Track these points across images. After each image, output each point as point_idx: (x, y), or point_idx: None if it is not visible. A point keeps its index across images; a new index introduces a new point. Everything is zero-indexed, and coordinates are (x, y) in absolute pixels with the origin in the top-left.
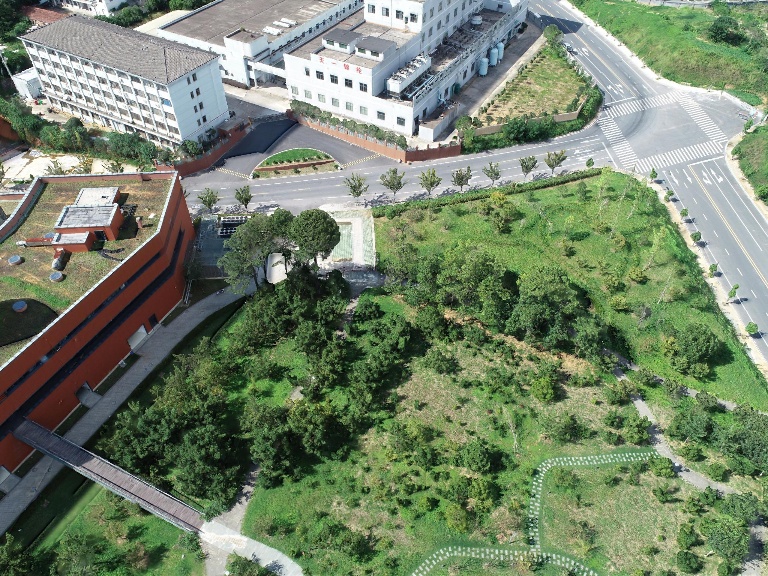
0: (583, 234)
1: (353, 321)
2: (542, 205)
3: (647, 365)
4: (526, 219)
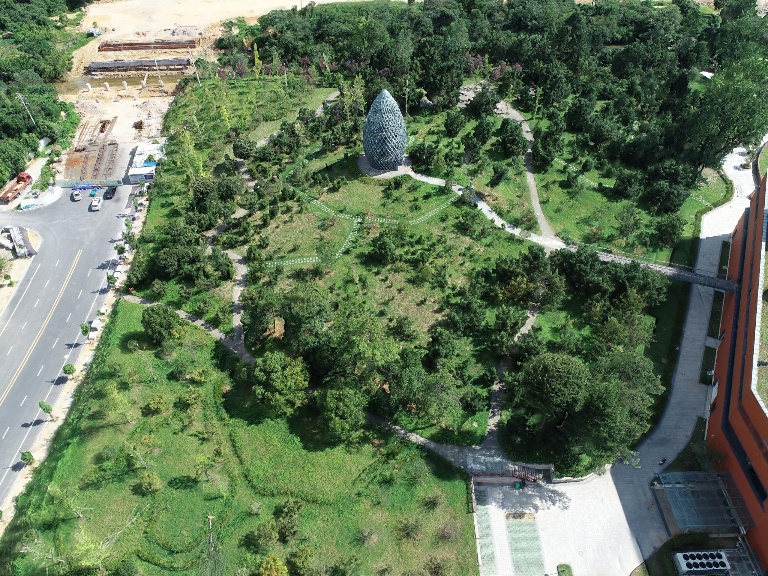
0: (178, 483)
1: (490, 399)
2: (201, 567)
3: (206, 336)
4: (242, 533)
